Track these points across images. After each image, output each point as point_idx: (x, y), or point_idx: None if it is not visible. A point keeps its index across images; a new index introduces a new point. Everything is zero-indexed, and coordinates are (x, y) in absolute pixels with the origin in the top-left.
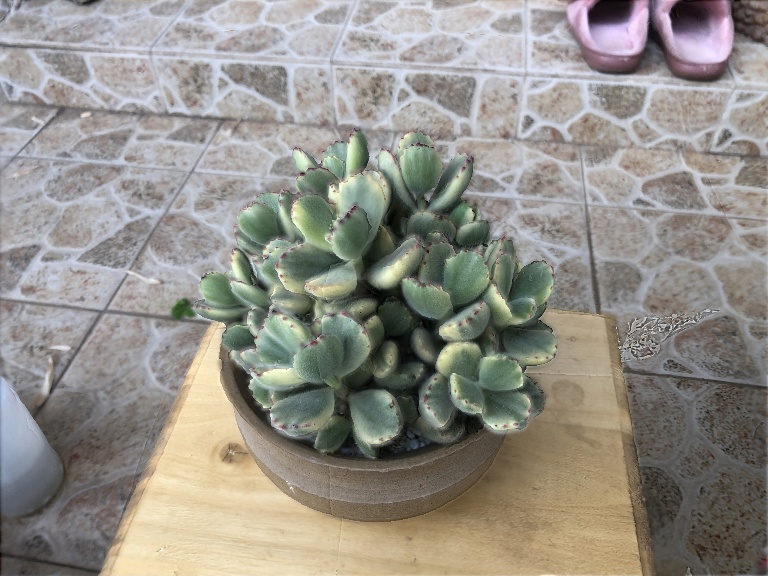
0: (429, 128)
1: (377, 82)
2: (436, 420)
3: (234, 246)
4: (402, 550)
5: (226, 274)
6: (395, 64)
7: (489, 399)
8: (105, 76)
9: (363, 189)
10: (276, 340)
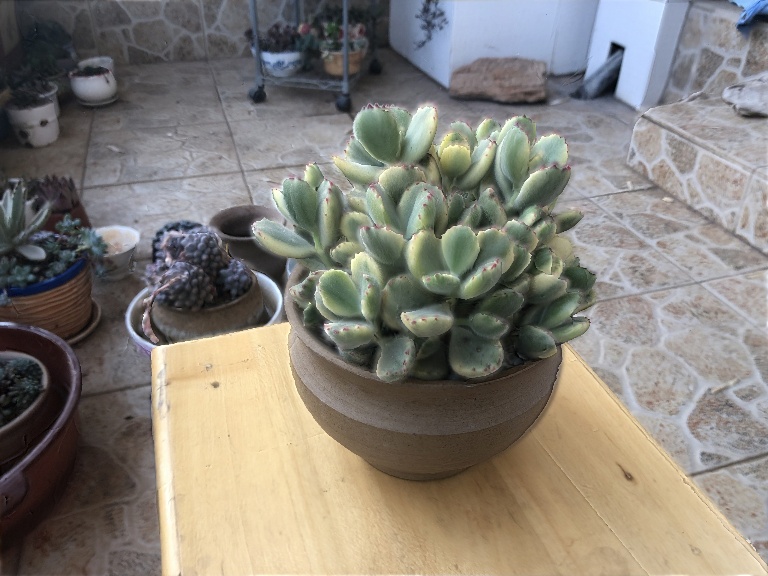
0: None
1: None
2: None
3: (659, 352)
4: (330, 479)
5: None
6: None
7: (358, 321)
8: (704, 175)
9: None
10: None
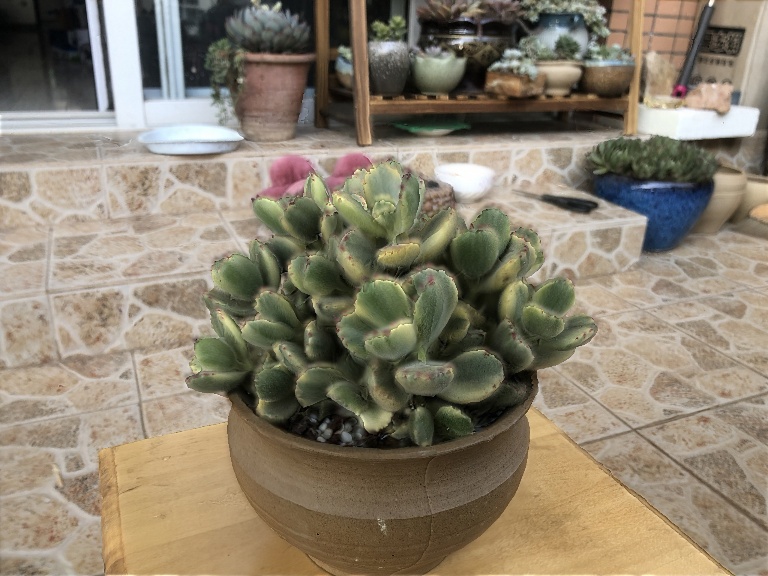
0: (167, 338)
1: (103, 303)
2: (529, 353)
3: None
4: None
5: None
6: (120, 281)
7: None
8: None
9: (387, 177)
10: (363, 323)
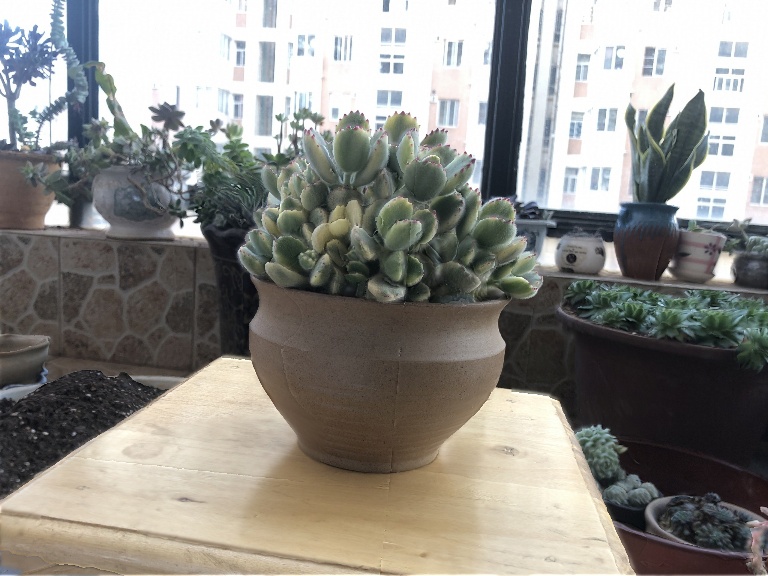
0: None
1: None
2: None
3: None
4: None
5: (519, 259)
6: None
7: None
8: None
9: None
10: None
